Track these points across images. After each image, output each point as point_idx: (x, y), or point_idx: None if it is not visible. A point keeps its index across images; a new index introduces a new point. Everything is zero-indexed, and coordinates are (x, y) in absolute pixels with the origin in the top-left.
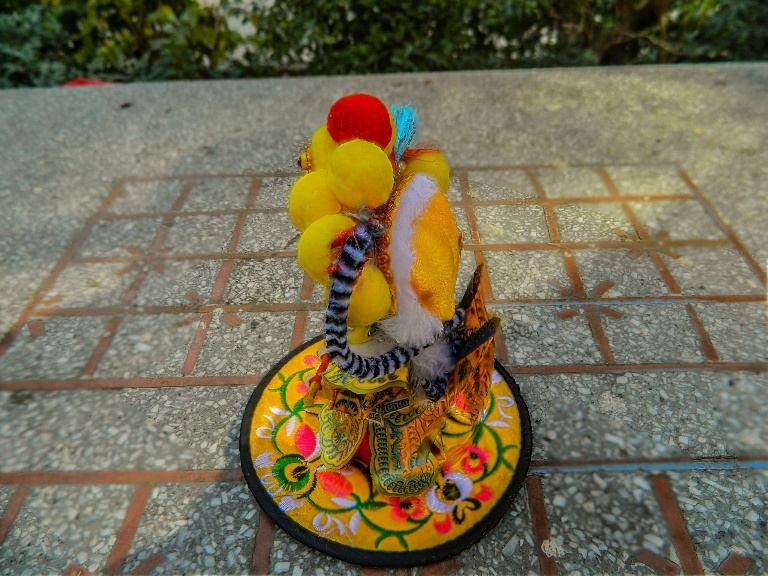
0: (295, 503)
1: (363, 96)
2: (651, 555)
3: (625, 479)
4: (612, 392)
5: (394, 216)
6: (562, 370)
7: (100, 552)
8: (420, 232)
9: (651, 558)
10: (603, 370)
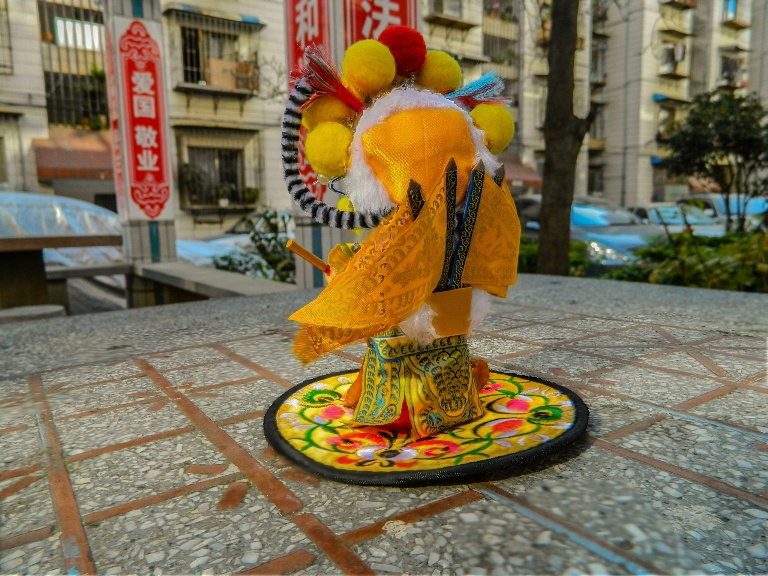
0: (295, 404)
1: None
2: None
3: (581, 555)
4: (716, 511)
5: None
6: (672, 469)
7: (206, 384)
8: (401, 117)
9: None
10: (739, 494)
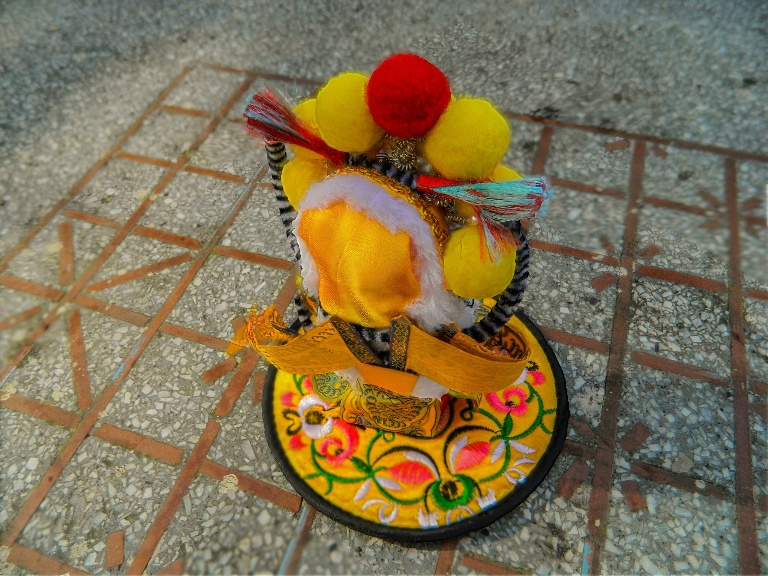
0: None
1: (417, 71)
2: (175, 574)
3: None
4: None
5: (342, 174)
6: None
7: None
8: (342, 216)
9: (174, 572)
10: None
